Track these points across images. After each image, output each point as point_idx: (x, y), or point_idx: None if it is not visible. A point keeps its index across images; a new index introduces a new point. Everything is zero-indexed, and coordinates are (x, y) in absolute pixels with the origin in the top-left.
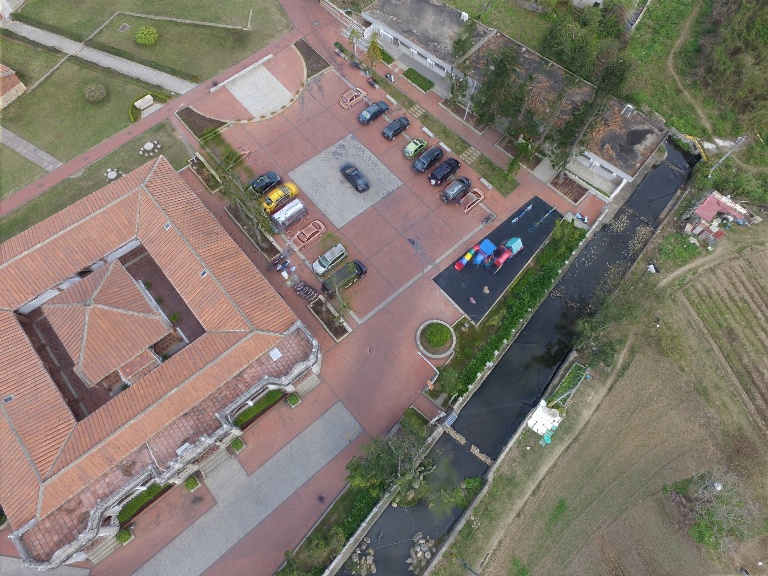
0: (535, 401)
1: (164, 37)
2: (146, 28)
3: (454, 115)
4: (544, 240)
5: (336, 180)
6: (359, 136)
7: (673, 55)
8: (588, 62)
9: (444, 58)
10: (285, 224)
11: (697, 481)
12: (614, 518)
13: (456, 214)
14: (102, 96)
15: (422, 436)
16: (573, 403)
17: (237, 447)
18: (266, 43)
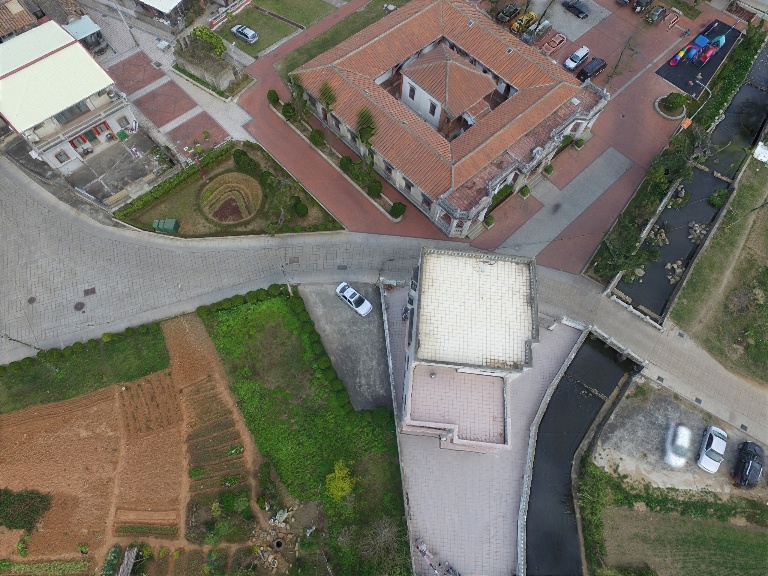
0: (750, 147)
1: None
2: None
3: None
4: (731, 47)
5: (560, 11)
6: None
7: None
8: None
9: None
10: (539, 34)
11: None
12: None
13: (659, 32)
14: None
15: None
16: None
17: (552, 169)
18: None
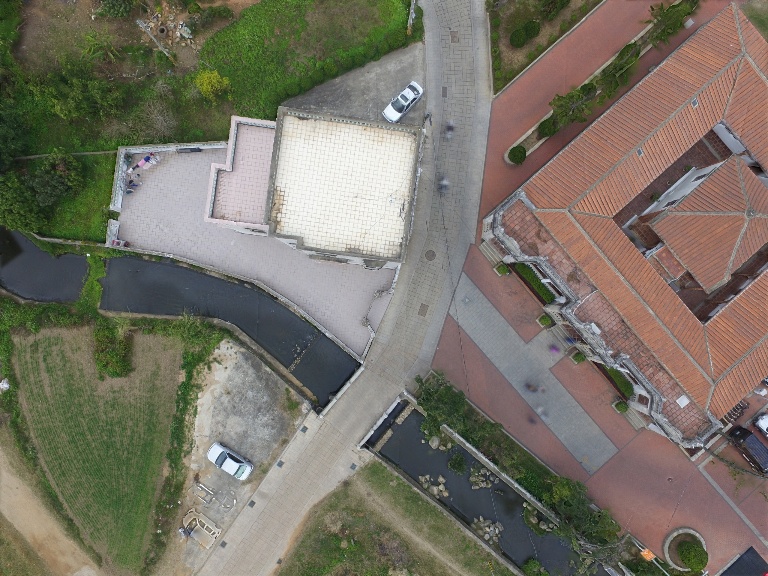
0: None
1: None
2: None
3: None
4: None
5: None
6: None
7: None
8: None
9: None
10: None
11: None
12: None
13: None
14: None
15: None
16: None
17: (579, 360)
18: None
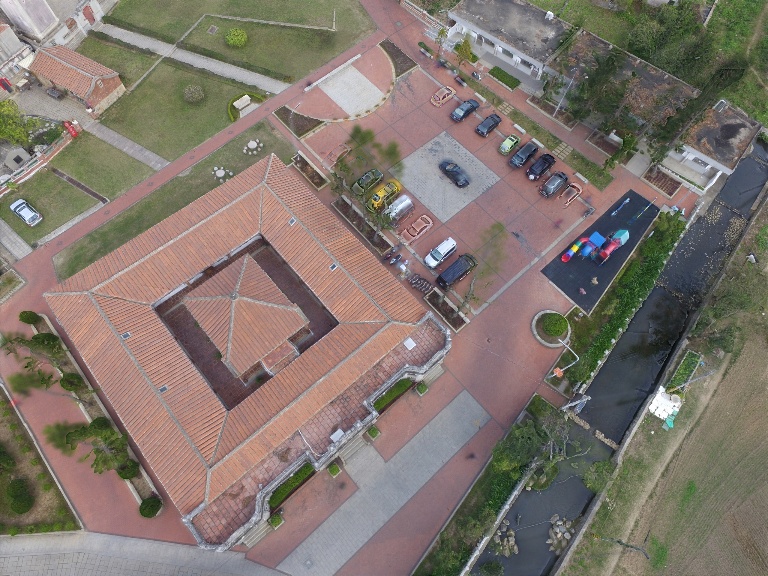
0: (651, 388)
1: (252, 38)
2: (237, 30)
3: (543, 112)
4: (644, 232)
5: (436, 176)
6: (453, 133)
7: (750, 51)
8: (675, 59)
9: (534, 56)
10: (395, 219)
11: None
12: (743, 498)
13: (556, 208)
14: (201, 96)
15: None
16: (691, 389)
17: (375, 434)
18: (352, 43)
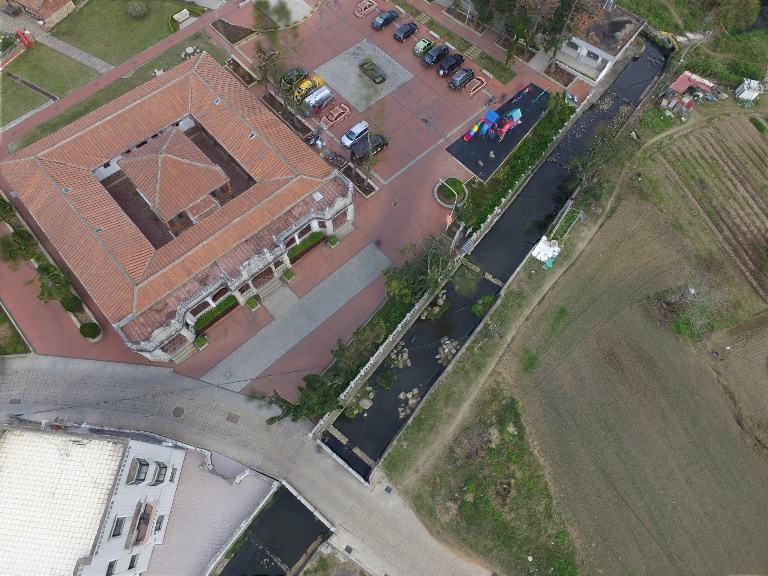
0: (537, 240)
1: None
2: None
3: (456, 21)
4: None
5: (356, 75)
6: (374, 40)
7: None
8: None
9: None
10: (315, 106)
11: (675, 291)
12: (607, 319)
13: (462, 99)
14: (144, 11)
15: (444, 260)
16: (569, 238)
17: (289, 275)
18: None
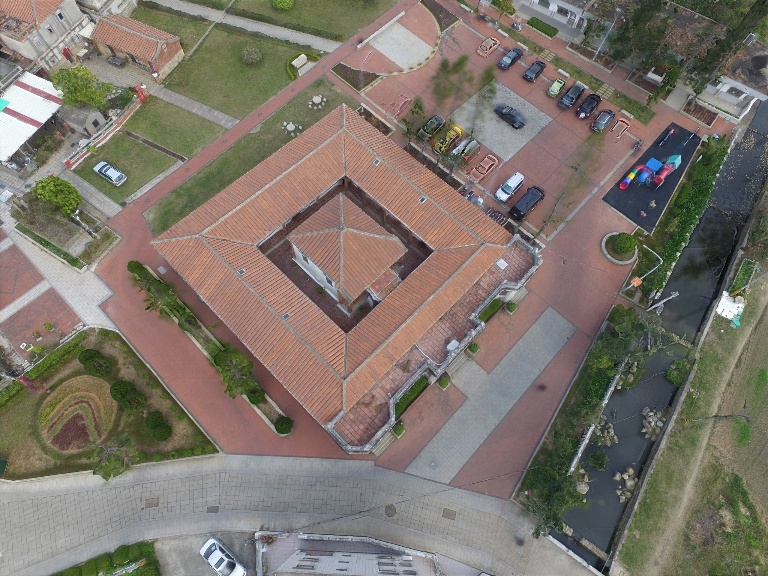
0: (714, 294)
1: (298, 2)
2: None
3: (582, 57)
4: (689, 159)
5: (493, 120)
6: (502, 80)
7: None
8: None
9: (573, 3)
10: (464, 159)
11: None
12: None
13: (607, 142)
14: (259, 58)
15: None
16: (751, 292)
17: (477, 349)
18: (394, 2)
